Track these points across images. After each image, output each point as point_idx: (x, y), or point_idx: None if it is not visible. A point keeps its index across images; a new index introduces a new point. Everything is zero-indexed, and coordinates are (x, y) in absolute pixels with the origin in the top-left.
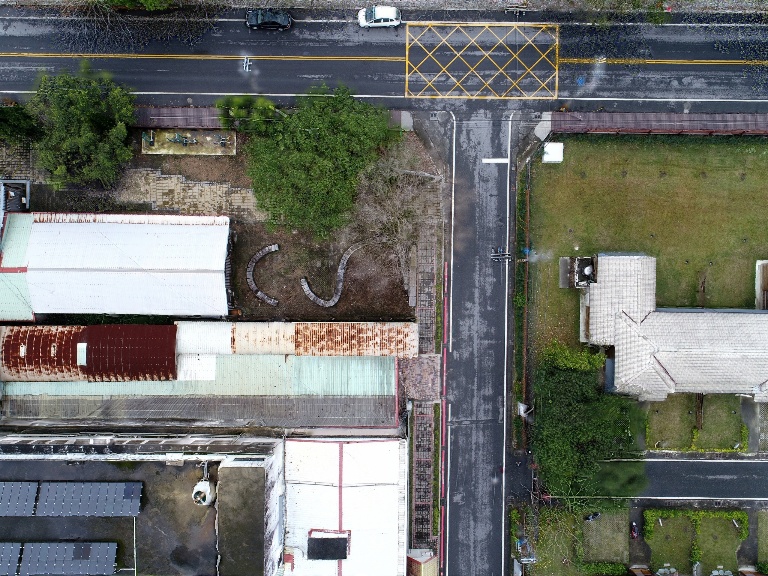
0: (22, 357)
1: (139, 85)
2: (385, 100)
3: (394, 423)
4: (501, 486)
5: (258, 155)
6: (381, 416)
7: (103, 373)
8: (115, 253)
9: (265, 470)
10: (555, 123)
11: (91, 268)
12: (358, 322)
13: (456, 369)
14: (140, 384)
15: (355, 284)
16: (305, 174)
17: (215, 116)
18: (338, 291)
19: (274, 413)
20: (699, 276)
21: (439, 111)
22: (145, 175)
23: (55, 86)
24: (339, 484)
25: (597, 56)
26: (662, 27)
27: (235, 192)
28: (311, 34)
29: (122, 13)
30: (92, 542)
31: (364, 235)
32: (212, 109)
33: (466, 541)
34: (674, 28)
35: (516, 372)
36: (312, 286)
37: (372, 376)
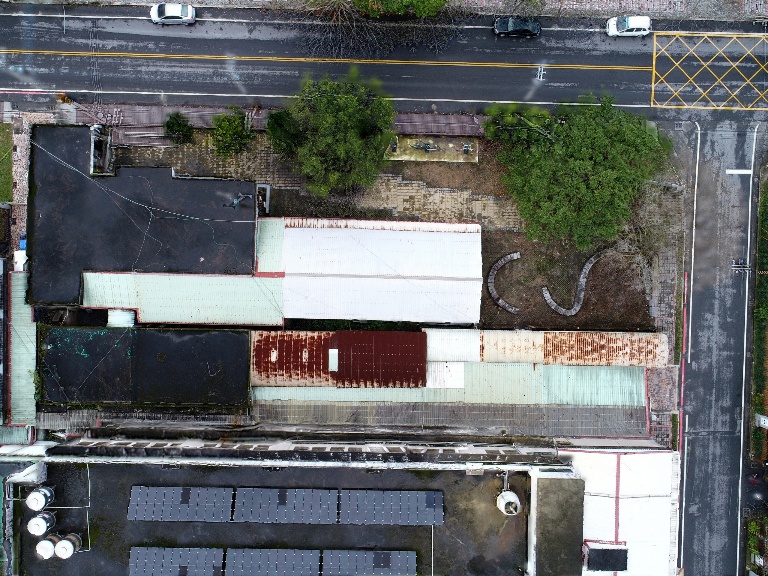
0: (273, 362)
1: (383, 91)
2: (630, 109)
3: (647, 434)
4: (737, 498)
5: (506, 163)
6: (635, 427)
7: (353, 379)
8: (371, 259)
9: (584, 482)
10: None
11: (349, 274)
12: (606, 332)
13: (694, 380)
14: (389, 391)
15: (595, 293)
16: (547, 182)
17: (460, 123)
18: (580, 300)
19: (524, 422)
20: None
21: (684, 121)
22: (386, 181)
23: (322, 91)
24: (616, 495)
25: None
26: None
27: (476, 199)
28: (558, 42)
29: (368, 18)
30: (391, 550)
31: (606, 244)
32: (457, 116)
33: (701, 552)
34: None
35: (755, 384)
36: (552, 295)
37: (621, 386)
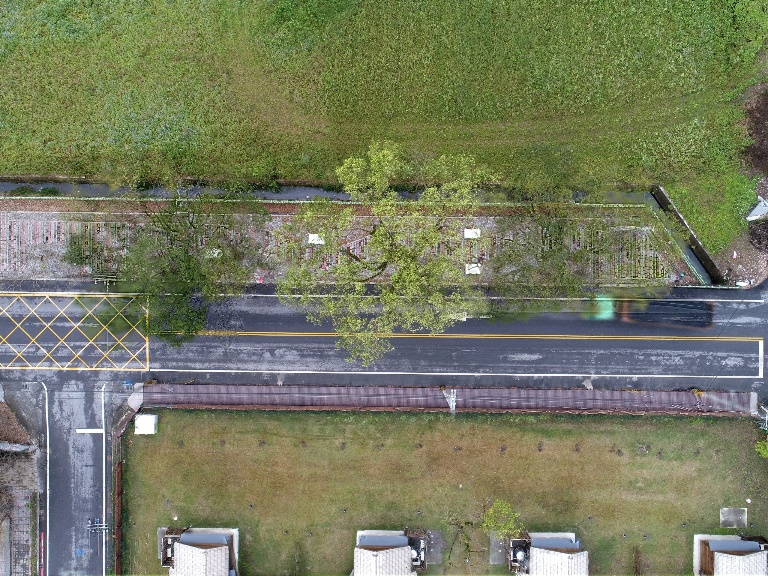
0: None
1: None
2: None
3: None
4: None
5: None
6: None
7: None
8: None
9: None
10: (147, 395)
11: None
12: None
13: None
14: None
15: None
16: None
17: None
18: None
19: None
20: (299, 547)
21: (30, 382)
22: None
23: None
24: None
25: (187, 328)
26: (254, 298)
27: None
28: None
29: None
30: None
31: None
32: None
33: None
34: (266, 299)
35: None
36: None
37: None
